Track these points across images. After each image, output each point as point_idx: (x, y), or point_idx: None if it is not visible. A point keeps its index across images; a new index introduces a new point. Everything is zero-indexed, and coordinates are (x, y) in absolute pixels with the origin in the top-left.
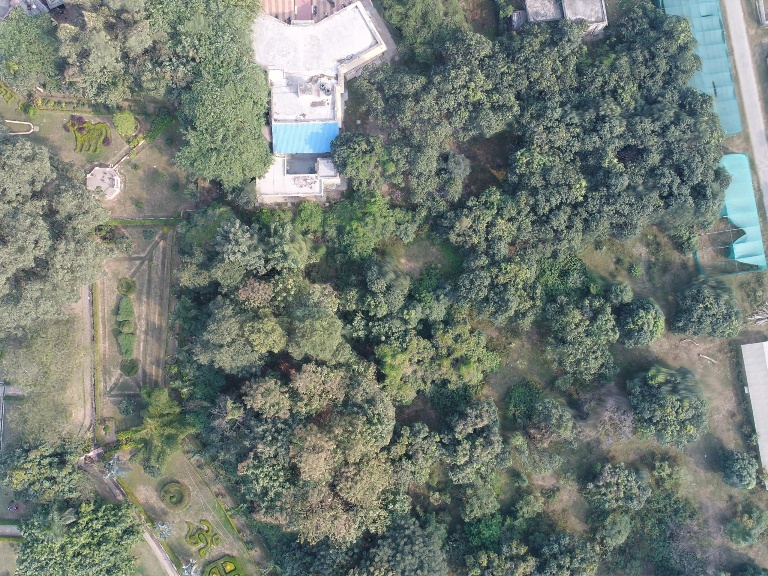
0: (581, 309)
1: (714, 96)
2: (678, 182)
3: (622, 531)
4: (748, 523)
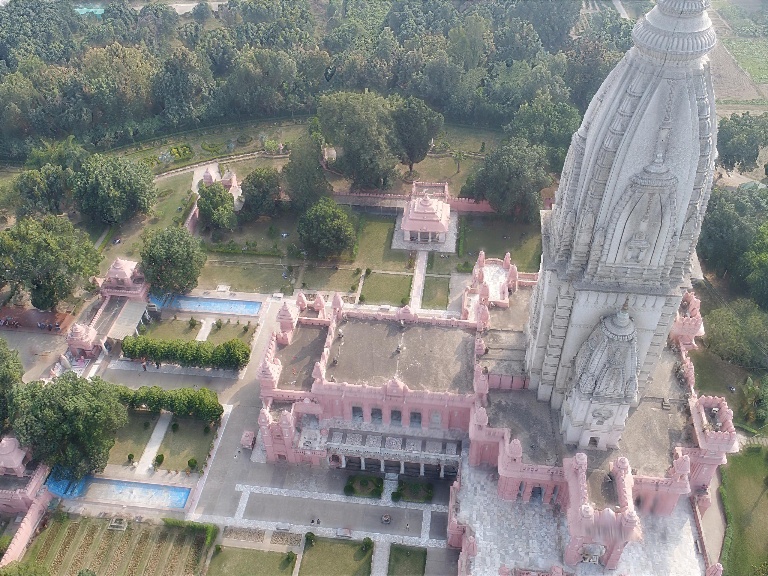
0: None
1: None
2: (46, 5)
3: None
4: None
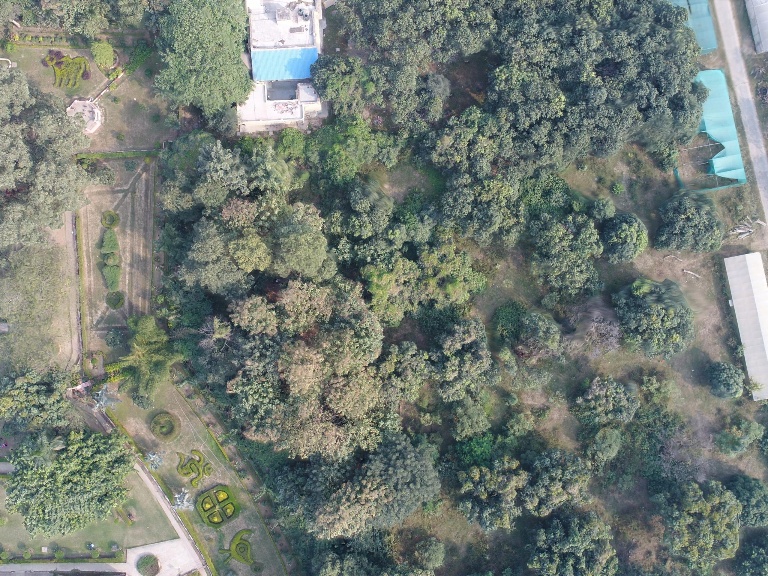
0: (564, 224)
1: (689, 13)
2: (656, 94)
3: (613, 445)
4: (737, 434)
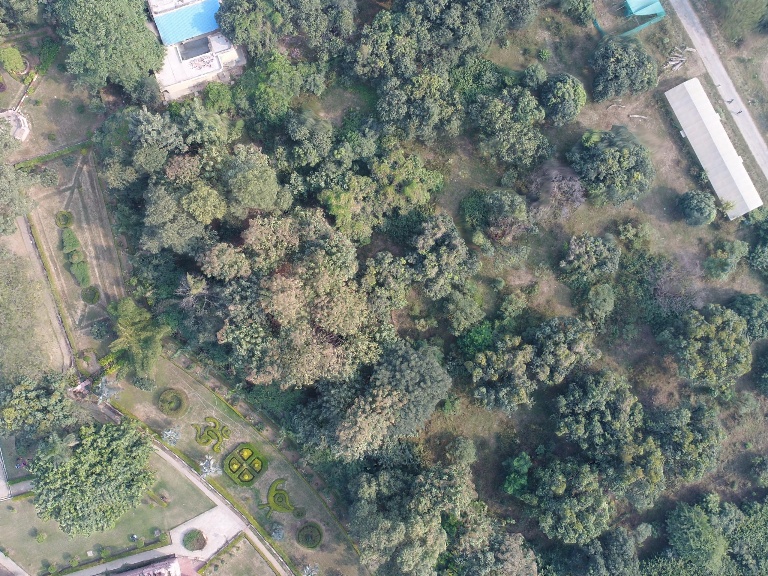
0: (501, 99)
1: None
2: None
3: (607, 299)
4: (723, 256)
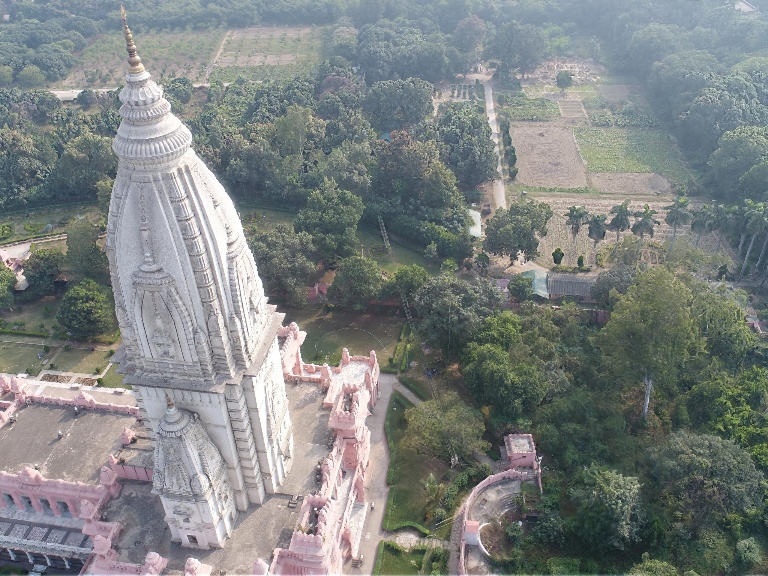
0: None
1: None
2: None
3: None
4: None
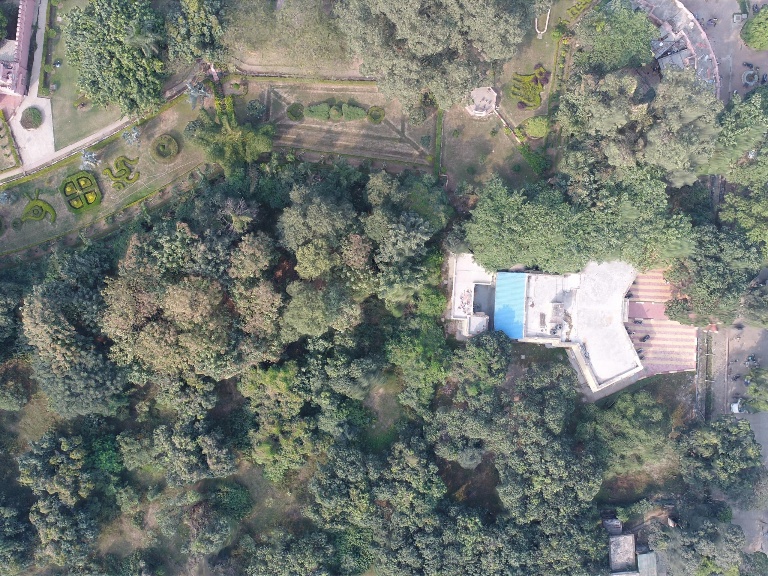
0: (318, 568)
1: None
2: None
3: None
4: None
